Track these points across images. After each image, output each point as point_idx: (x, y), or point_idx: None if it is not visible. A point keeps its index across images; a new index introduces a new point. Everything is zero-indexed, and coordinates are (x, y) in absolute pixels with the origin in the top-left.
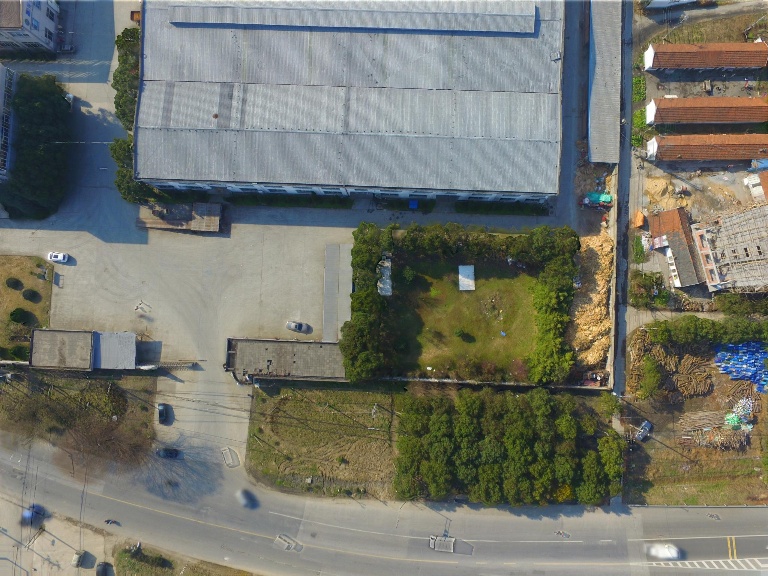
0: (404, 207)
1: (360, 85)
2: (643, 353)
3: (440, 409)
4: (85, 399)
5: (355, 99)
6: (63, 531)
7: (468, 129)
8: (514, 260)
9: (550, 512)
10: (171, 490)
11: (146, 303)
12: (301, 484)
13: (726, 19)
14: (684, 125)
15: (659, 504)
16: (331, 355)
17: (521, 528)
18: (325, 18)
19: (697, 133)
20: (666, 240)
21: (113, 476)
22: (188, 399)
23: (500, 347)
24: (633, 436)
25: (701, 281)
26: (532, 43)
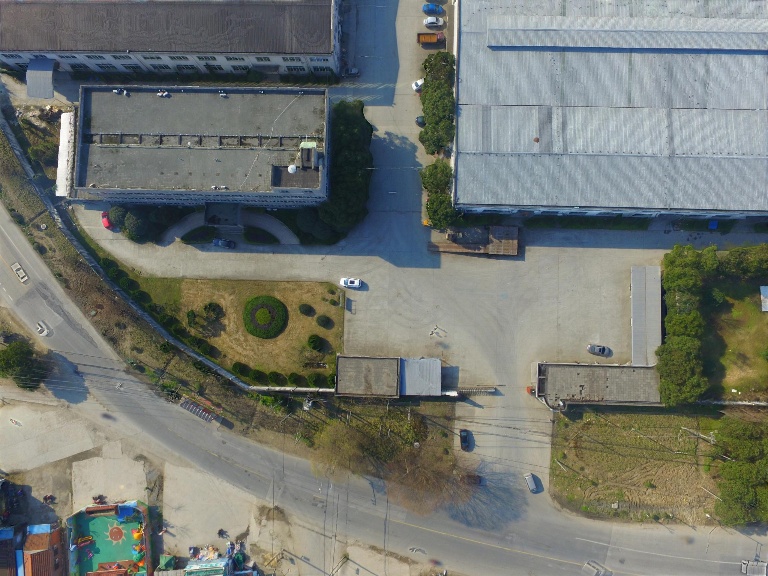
0: (702, 227)
1: (681, 106)
2: None
3: None
4: (386, 426)
5: (678, 121)
6: (367, 560)
7: None
8: None
9: None
10: (475, 517)
11: (441, 328)
12: (607, 509)
13: None
14: None
15: None
16: (645, 379)
17: None
18: (648, 39)
19: None
20: None
21: (415, 503)
22: (488, 425)
23: None
24: None
25: None
26: None
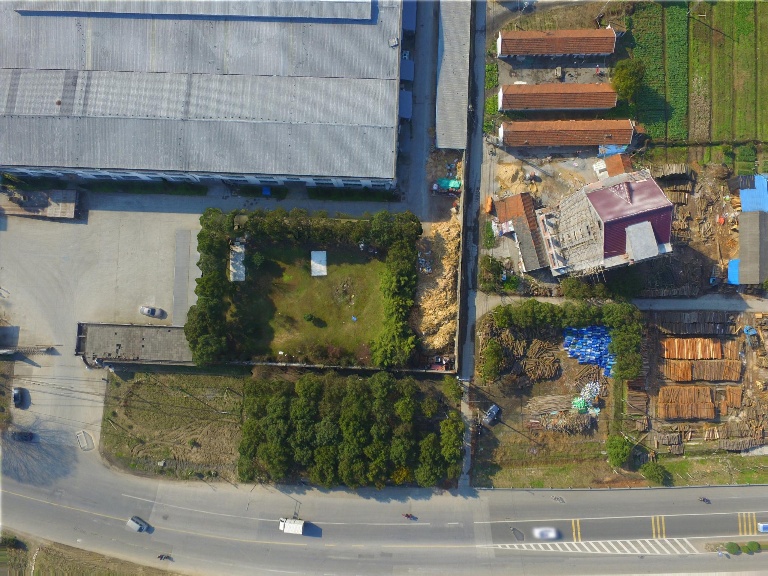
0: (258, 193)
1: (202, 72)
2: (490, 337)
3: (278, 392)
4: None
5: (196, 86)
6: None
7: (306, 115)
8: (366, 246)
9: (398, 495)
10: (26, 473)
11: (4, 289)
12: (154, 467)
13: (578, 6)
14: (533, 111)
15: (505, 487)
16: (179, 339)
17: (369, 511)
18: (165, 6)
19: (549, 119)
20: (512, 225)
21: None
22: (44, 383)
23: (351, 332)
24: (481, 420)
25: (544, 266)
26: (370, 30)
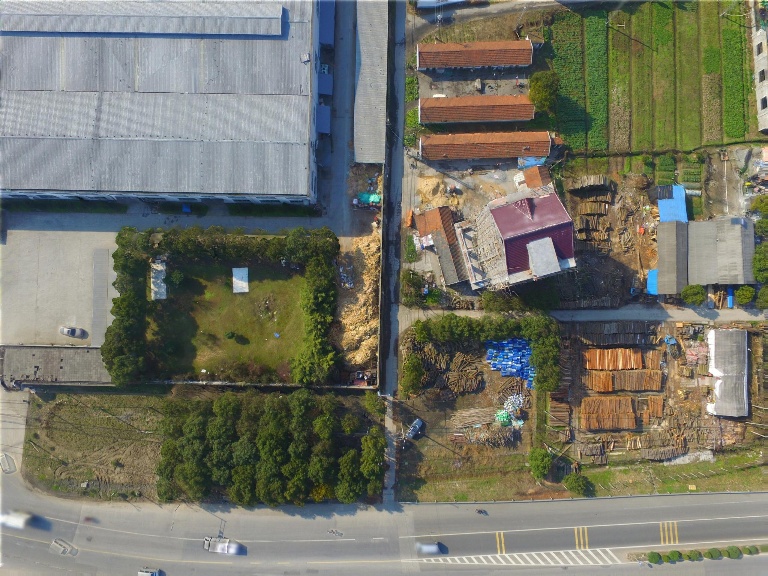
0: (178, 211)
1: (113, 90)
2: (412, 352)
3: (195, 412)
4: None
5: (107, 104)
6: None
7: (218, 132)
8: (287, 261)
9: (323, 511)
10: None
11: None
12: (77, 488)
13: (497, 18)
14: (453, 124)
15: (430, 501)
16: (97, 360)
17: (294, 528)
18: (73, 23)
19: (469, 132)
20: (431, 239)
21: None
22: None
23: (273, 348)
24: (405, 434)
25: (463, 279)
26: (282, 45)
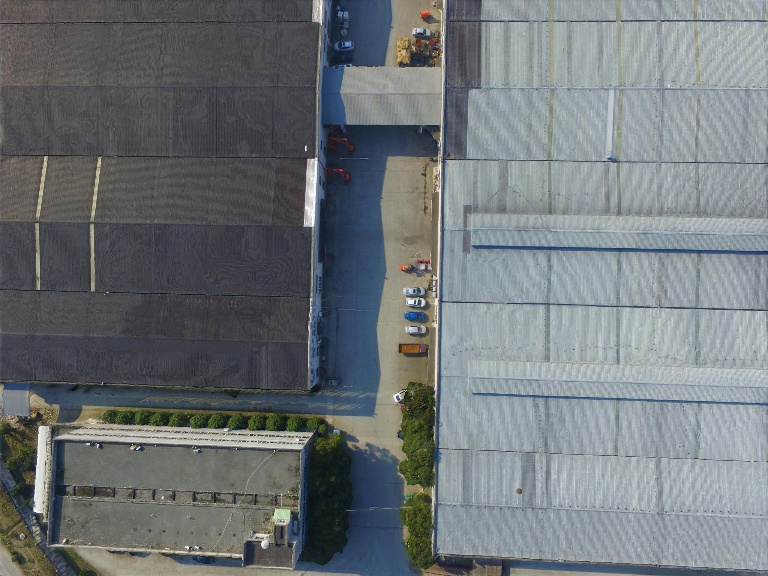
0: None
1: (671, 456)
2: None
3: None
4: None
5: (667, 472)
6: None
7: None
8: None
9: None
10: None
11: None
12: None
13: None
14: None
15: None
16: None
17: None
18: (636, 390)
19: None
20: None
21: None
22: None
23: None
24: None
25: None
26: None
